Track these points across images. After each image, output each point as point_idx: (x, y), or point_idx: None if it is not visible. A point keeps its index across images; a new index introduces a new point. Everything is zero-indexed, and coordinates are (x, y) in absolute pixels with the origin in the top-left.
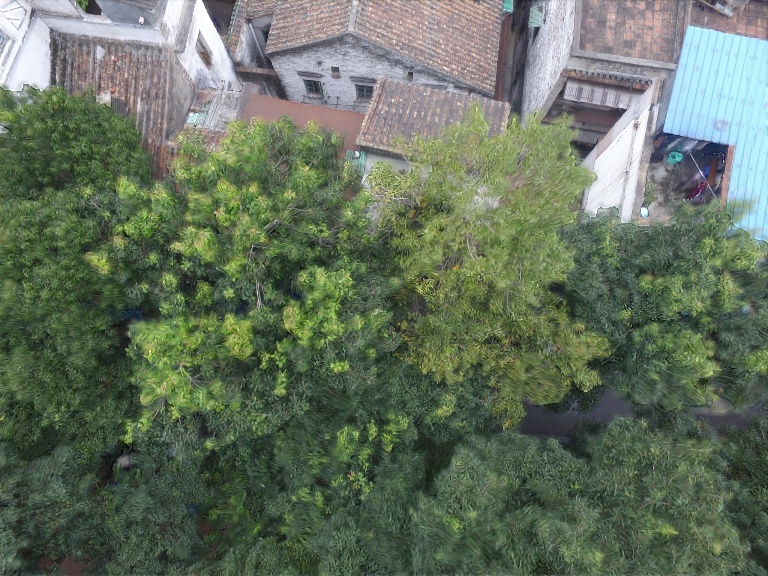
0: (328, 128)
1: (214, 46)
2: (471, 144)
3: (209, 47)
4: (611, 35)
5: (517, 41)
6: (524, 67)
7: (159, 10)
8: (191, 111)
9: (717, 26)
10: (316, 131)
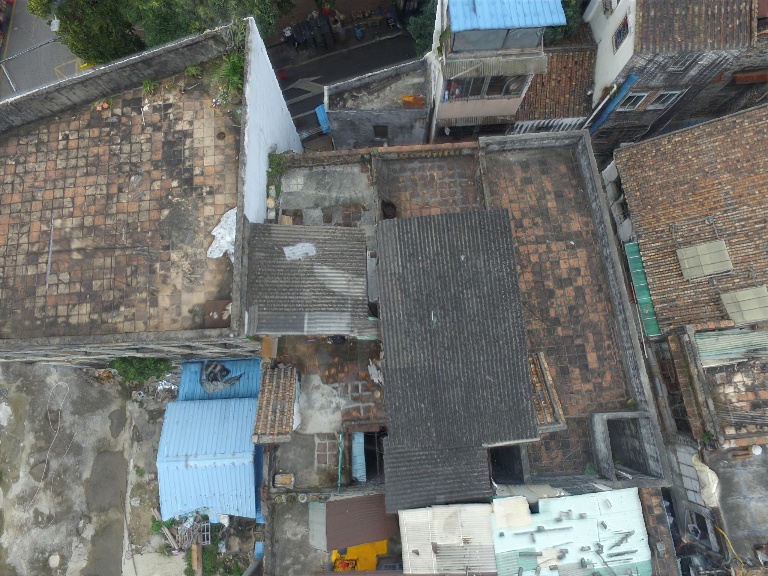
0: None
1: None
2: None
3: None
4: (546, 186)
5: None
6: None
7: None
8: None
9: None
10: None
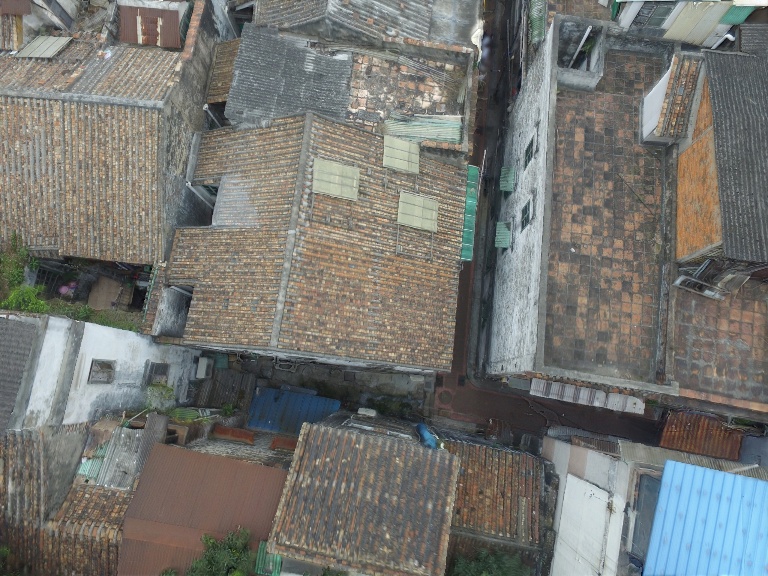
0: (240, 498)
1: (119, 350)
2: (409, 537)
3: (110, 359)
4: (583, 324)
5: (489, 216)
6: (494, 269)
7: (20, 405)
8: (84, 456)
9: (707, 312)
10: (226, 503)
